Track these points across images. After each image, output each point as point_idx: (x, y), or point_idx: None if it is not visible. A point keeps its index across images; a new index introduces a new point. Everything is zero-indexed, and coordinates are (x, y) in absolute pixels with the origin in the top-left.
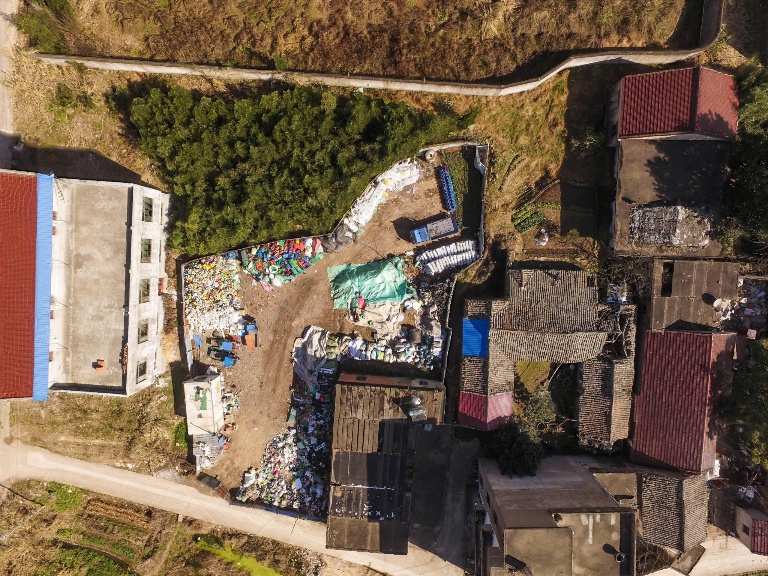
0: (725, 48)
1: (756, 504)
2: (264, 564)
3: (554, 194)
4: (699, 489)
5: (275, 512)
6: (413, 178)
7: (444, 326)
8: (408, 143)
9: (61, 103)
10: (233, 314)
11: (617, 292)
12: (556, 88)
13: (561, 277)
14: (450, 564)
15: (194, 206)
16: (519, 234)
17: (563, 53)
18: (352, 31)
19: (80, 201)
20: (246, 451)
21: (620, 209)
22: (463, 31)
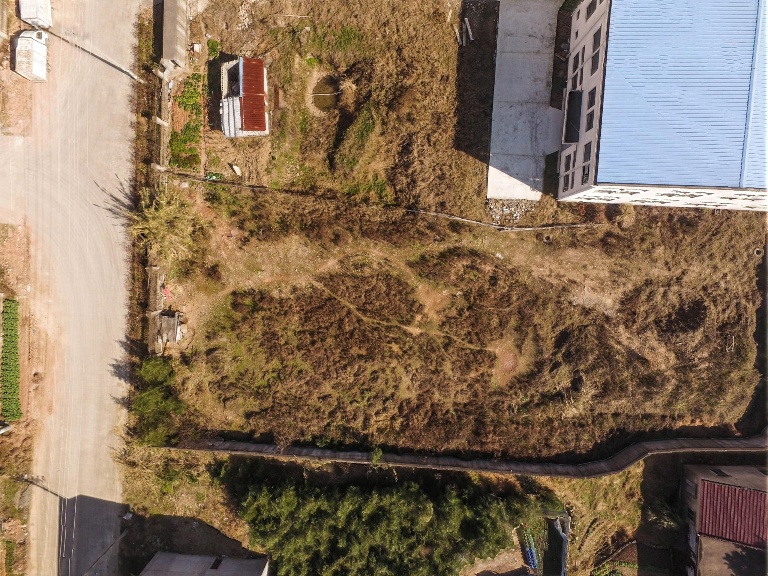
0: None
1: None
2: None
3: (631, 554)
4: None
5: None
6: None
7: None
8: None
9: (168, 478)
10: None
11: None
12: None
13: None
14: None
15: None
16: None
17: (639, 432)
18: (440, 412)
19: None
20: None
21: None
22: (545, 414)
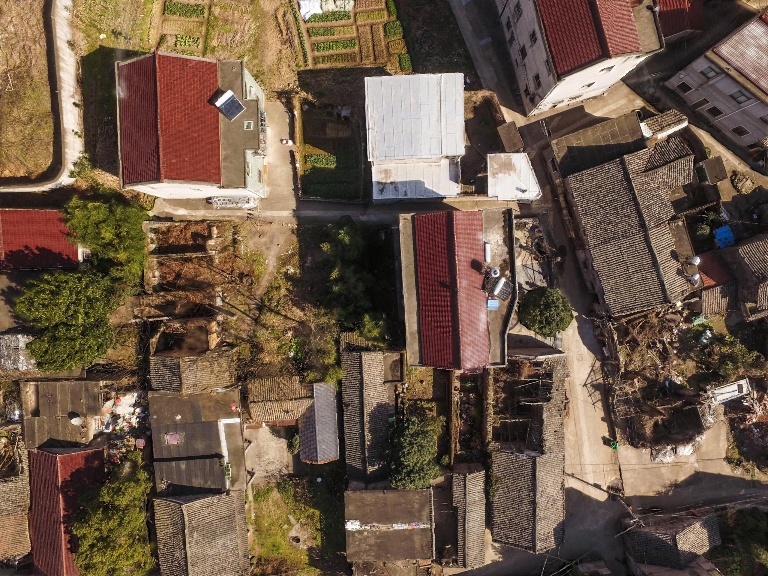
0: (101, 174)
1: None
2: None
3: None
4: None
5: None
6: None
7: None
8: None
9: None
10: None
11: (10, 411)
12: None
13: None
14: None
15: None
16: None
17: None
18: None
19: None
20: None
21: None
22: None
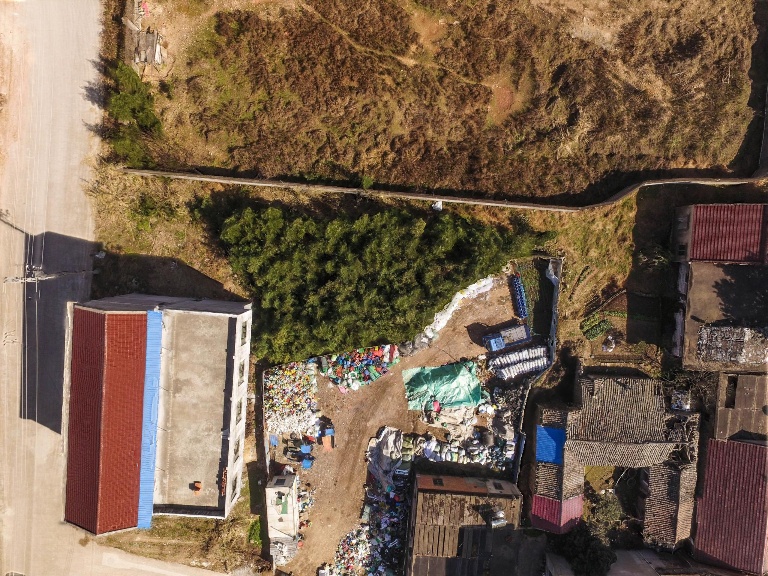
0: None
1: None
2: None
3: (621, 303)
4: None
5: None
6: (487, 287)
7: (517, 430)
8: (494, 267)
9: (145, 213)
10: (311, 417)
11: (681, 400)
12: (625, 205)
13: (629, 386)
14: None
15: (284, 323)
16: (587, 340)
17: (633, 173)
18: (433, 148)
19: (181, 328)
20: (320, 547)
21: (689, 327)
22: (540, 151)
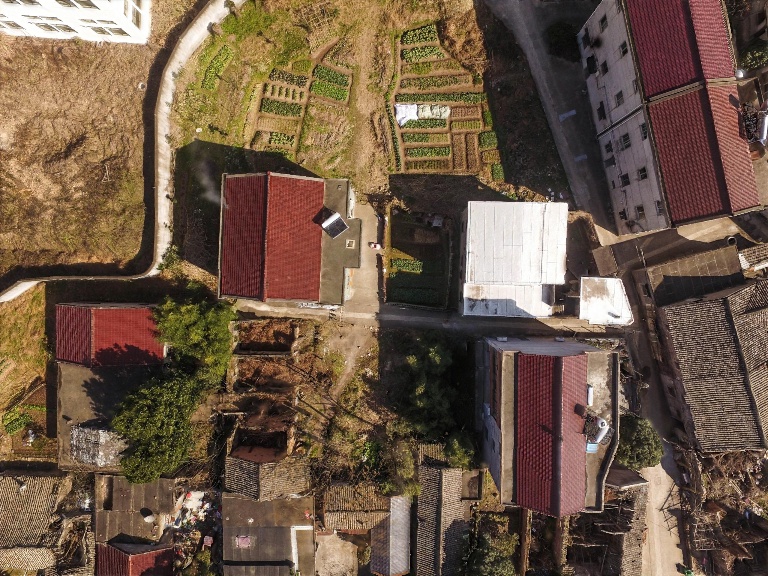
0: (187, 265)
1: None
2: None
3: (40, 397)
4: None
5: None
6: None
7: None
8: None
9: None
10: None
11: (80, 499)
12: (35, 299)
13: (27, 484)
14: None
15: None
16: (8, 434)
17: (36, 268)
18: None
19: None
20: None
21: (61, 426)
22: None
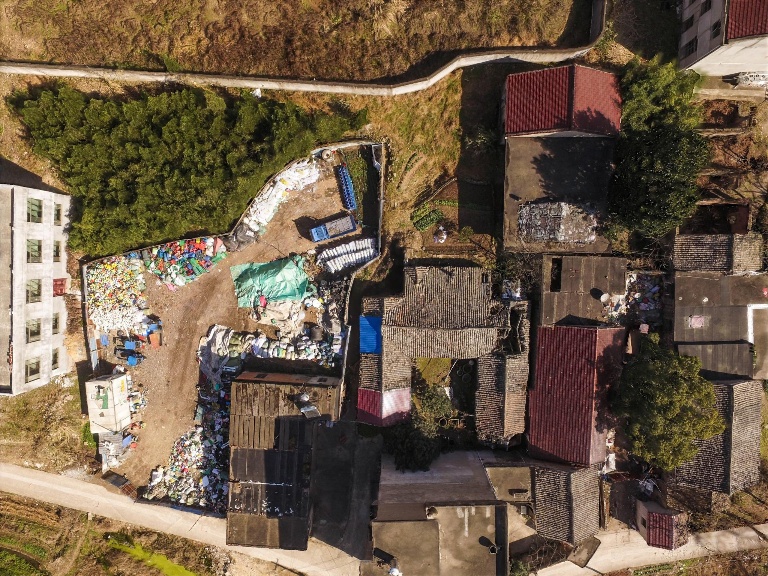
0: (614, 46)
1: (655, 497)
2: (174, 561)
3: (451, 192)
4: (590, 482)
5: (180, 509)
6: (312, 177)
7: (344, 323)
8: (294, 143)
9: None
10: (136, 314)
11: (511, 288)
12: (450, 87)
13: (456, 274)
14: (357, 560)
15: (87, 207)
16: (418, 232)
17: (455, 53)
18: (247, 33)
19: None
20: (154, 449)
21: (508, 206)
22: (356, 32)
